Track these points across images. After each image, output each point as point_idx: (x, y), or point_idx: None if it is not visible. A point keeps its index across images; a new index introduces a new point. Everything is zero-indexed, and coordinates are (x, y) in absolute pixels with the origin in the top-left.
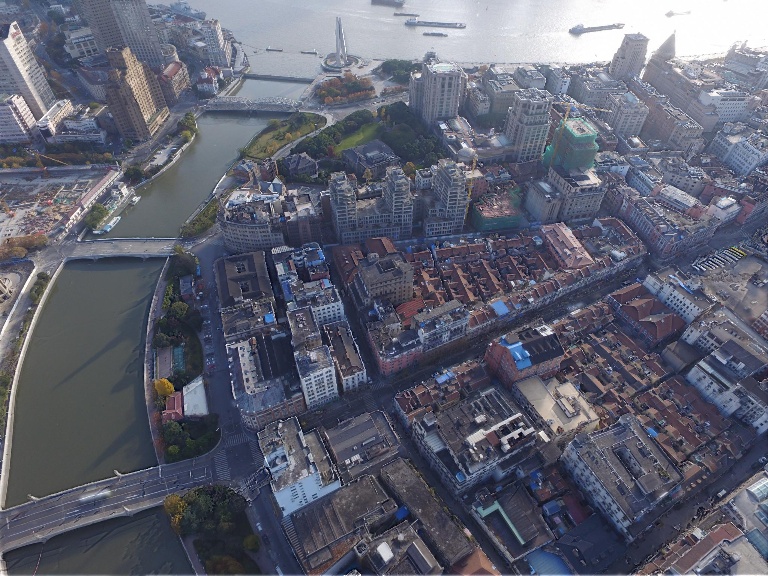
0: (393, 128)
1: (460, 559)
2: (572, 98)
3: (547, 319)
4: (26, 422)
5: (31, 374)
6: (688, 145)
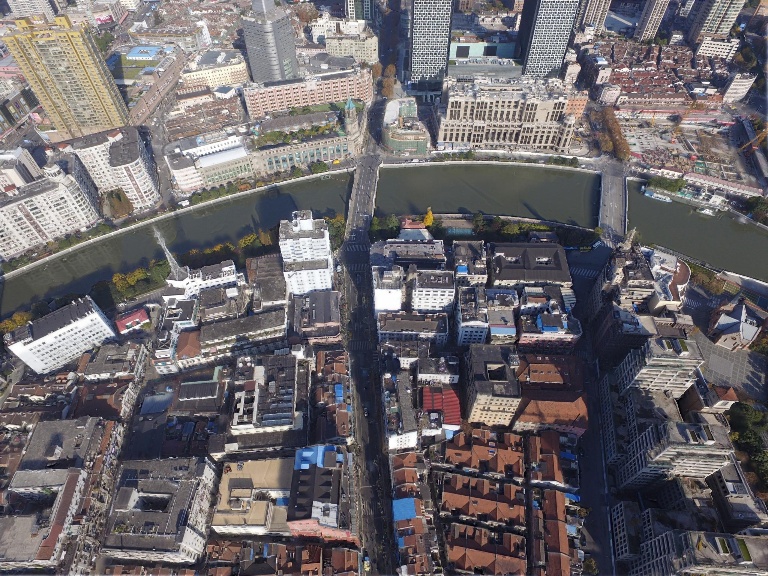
0: None
1: None
2: None
3: None
4: (442, 173)
5: (482, 172)
6: None
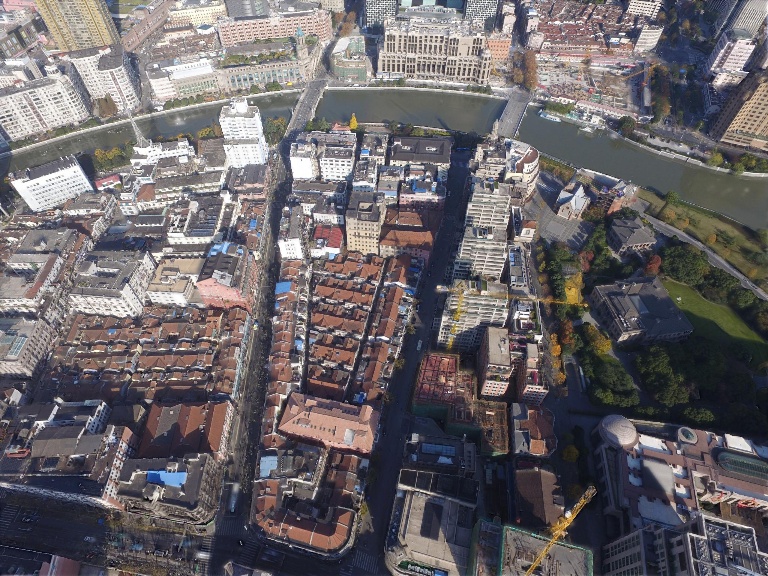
0: None
1: None
2: None
3: None
4: None
5: None
6: None
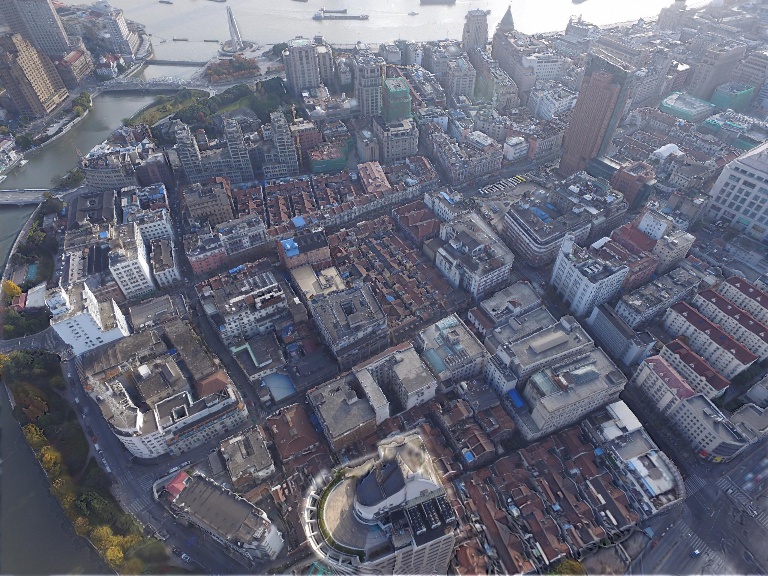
0: (263, 98)
1: (205, 376)
2: (422, 67)
3: None
4: None
5: None
6: (505, 100)
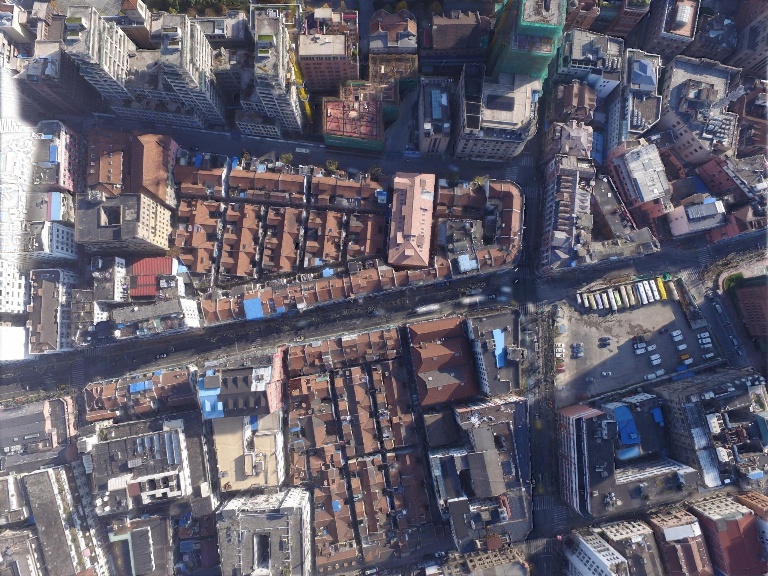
0: None
1: None
2: None
3: (331, 319)
4: None
5: None
6: (767, 53)
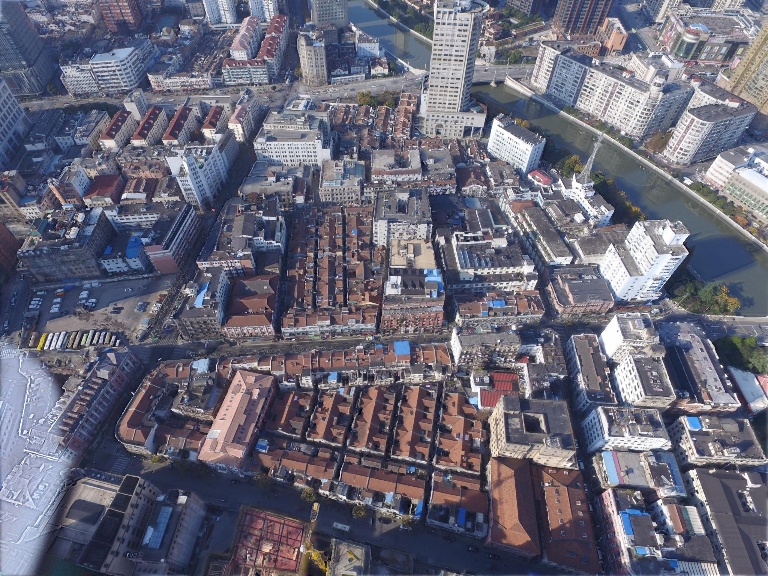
0: None
1: None
2: None
3: None
4: None
5: None
6: None
